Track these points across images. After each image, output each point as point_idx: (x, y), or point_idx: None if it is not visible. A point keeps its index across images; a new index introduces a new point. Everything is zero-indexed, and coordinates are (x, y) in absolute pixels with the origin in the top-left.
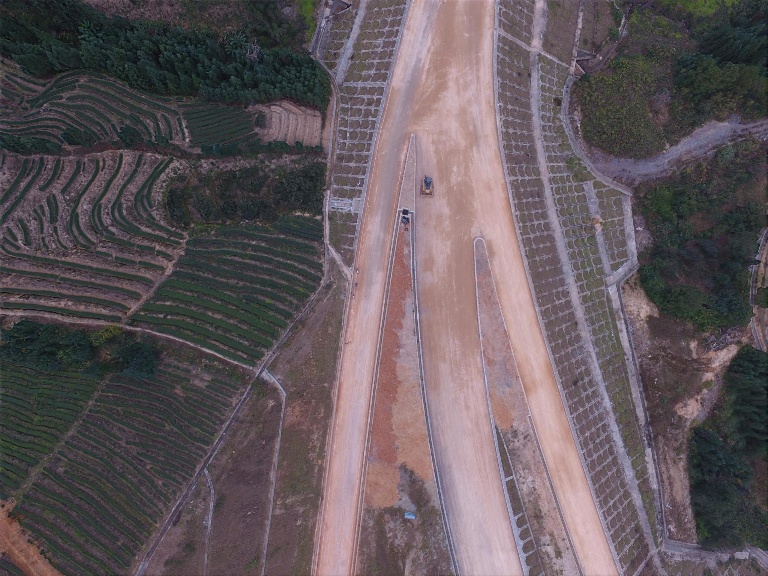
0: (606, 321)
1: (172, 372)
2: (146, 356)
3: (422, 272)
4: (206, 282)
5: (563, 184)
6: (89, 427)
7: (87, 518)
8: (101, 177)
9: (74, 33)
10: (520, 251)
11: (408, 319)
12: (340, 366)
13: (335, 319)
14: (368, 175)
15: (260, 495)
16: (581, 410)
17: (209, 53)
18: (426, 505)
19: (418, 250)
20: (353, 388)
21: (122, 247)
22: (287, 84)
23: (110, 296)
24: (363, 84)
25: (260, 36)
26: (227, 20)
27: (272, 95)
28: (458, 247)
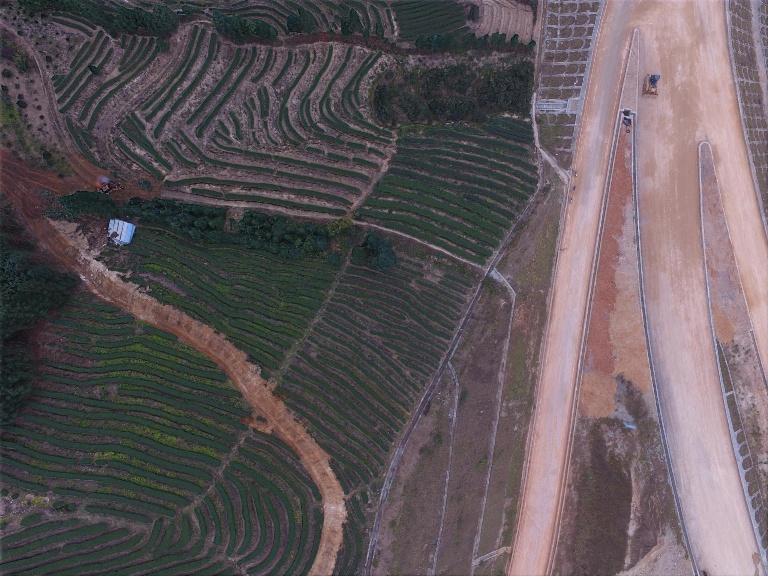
0: None
1: (405, 266)
2: (387, 246)
3: (643, 177)
4: (423, 180)
5: None
6: (333, 315)
7: (343, 402)
8: (311, 70)
9: None
10: (748, 157)
11: (628, 226)
12: (556, 273)
13: (552, 224)
14: (588, 72)
15: (490, 395)
16: None
17: None
18: (645, 416)
19: (639, 154)
20: (568, 296)
21: (332, 144)
22: None
23: (331, 190)
24: None
25: None
26: None
27: None
28: (681, 151)
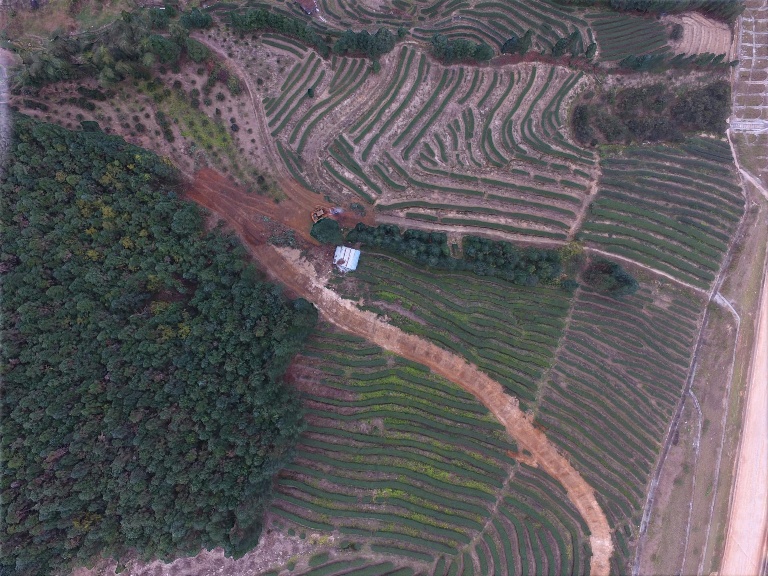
0: None
1: None
2: None
3: None
4: (634, 203)
5: None
6: (573, 344)
7: (598, 433)
8: (515, 91)
9: None
10: None
11: None
12: (763, 295)
13: (759, 245)
14: None
15: (717, 421)
16: None
17: None
18: None
19: None
20: None
21: (535, 166)
22: None
23: (547, 214)
24: None
25: None
26: None
27: (696, 3)
28: None
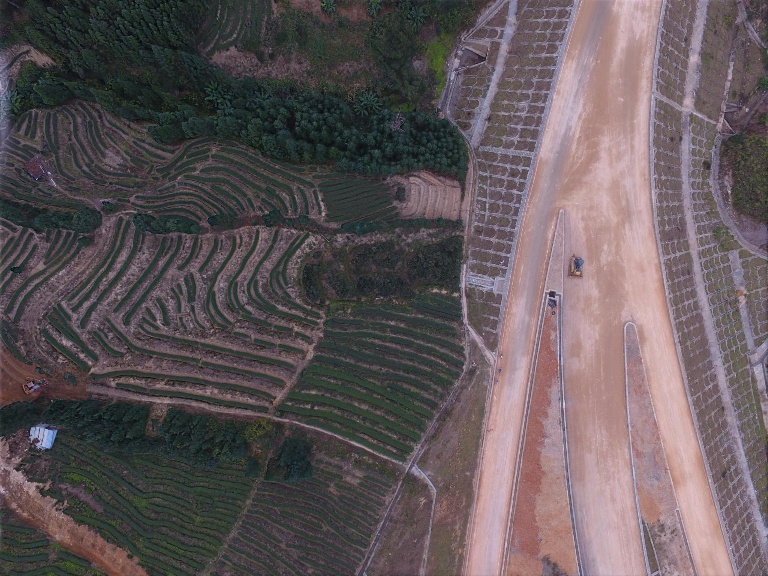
0: (750, 403)
1: (324, 469)
2: (303, 457)
3: (568, 358)
4: (348, 368)
5: (711, 256)
6: (249, 528)
7: None
8: (238, 254)
9: (197, 91)
10: (673, 337)
11: (554, 408)
12: (482, 454)
13: (478, 406)
14: (514, 254)
15: None
16: (729, 502)
17: (343, 118)
18: None
19: (565, 334)
20: (494, 476)
21: (259, 327)
22: (430, 156)
23: (255, 384)
24: (504, 151)
25: (391, 95)
26: (356, 77)
27: (414, 168)
28: (607, 332)
